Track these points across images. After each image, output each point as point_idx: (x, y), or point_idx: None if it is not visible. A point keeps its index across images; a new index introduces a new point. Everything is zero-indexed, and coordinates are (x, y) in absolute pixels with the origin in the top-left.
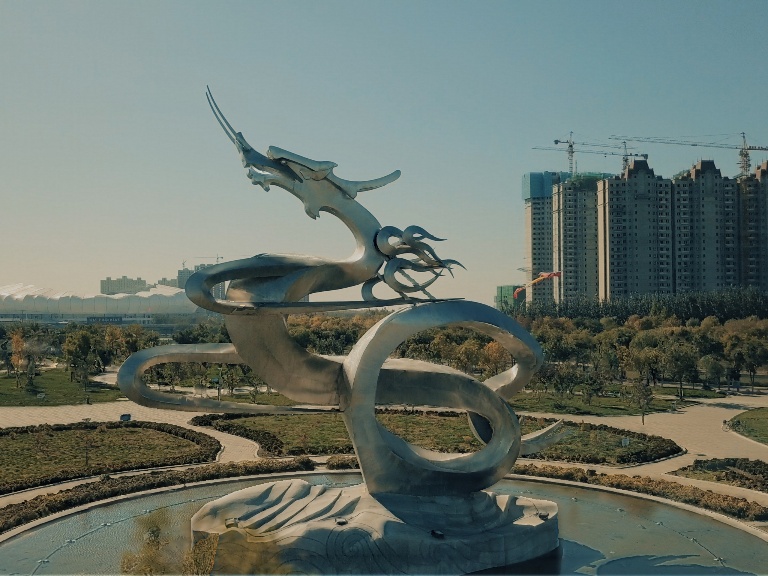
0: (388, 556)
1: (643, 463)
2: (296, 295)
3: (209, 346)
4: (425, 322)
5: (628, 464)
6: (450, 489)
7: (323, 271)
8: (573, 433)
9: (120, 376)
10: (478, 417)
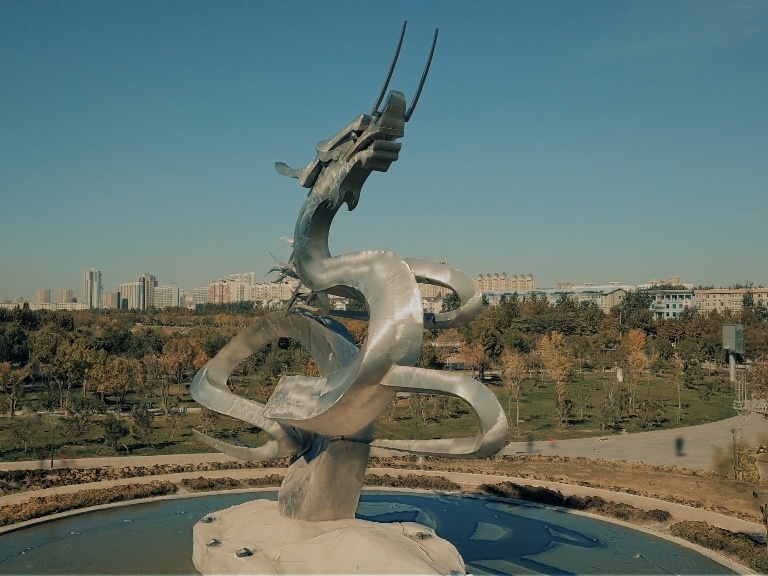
0: None
1: None
2: None
3: None
4: None
5: None
6: None
7: None
8: None
9: None
10: None
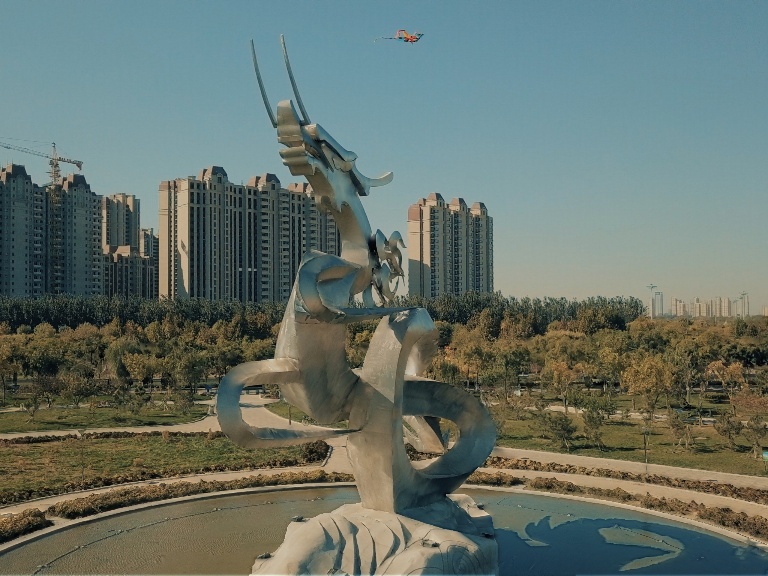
0: (483, 566)
1: (326, 459)
2: None
3: (273, 363)
4: (420, 330)
5: (317, 462)
6: (439, 495)
7: (357, 274)
8: (212, 442)
9: (220, 409)
10: (436, 422)
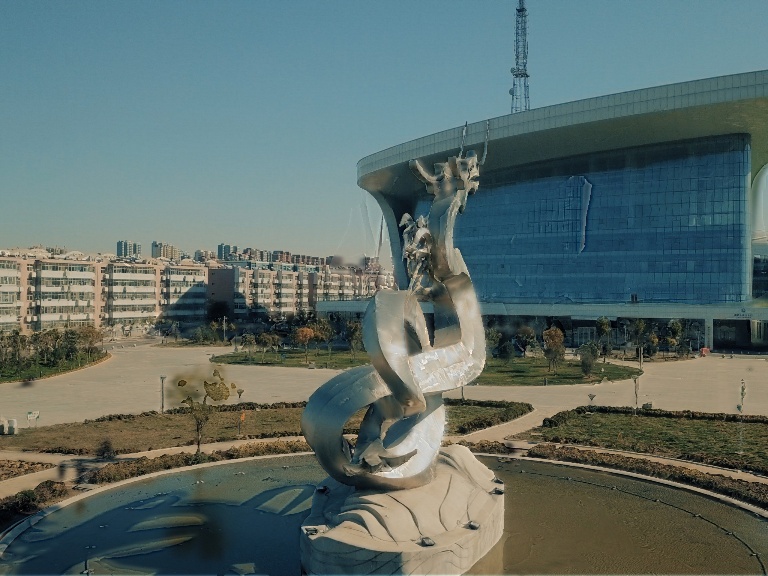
0: None
1: None
2: (442, 286)
3: None
4: None
5: None
6: None
7: None
8: None
9: None
10: None
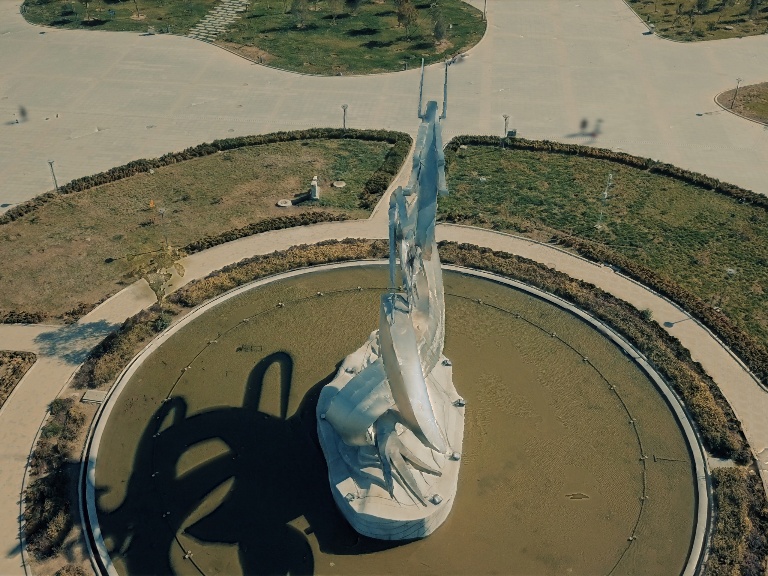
0: None
1: None
2: None
3: None
4: None
5: None
6: None
7: None
8: None
9: None
10: None
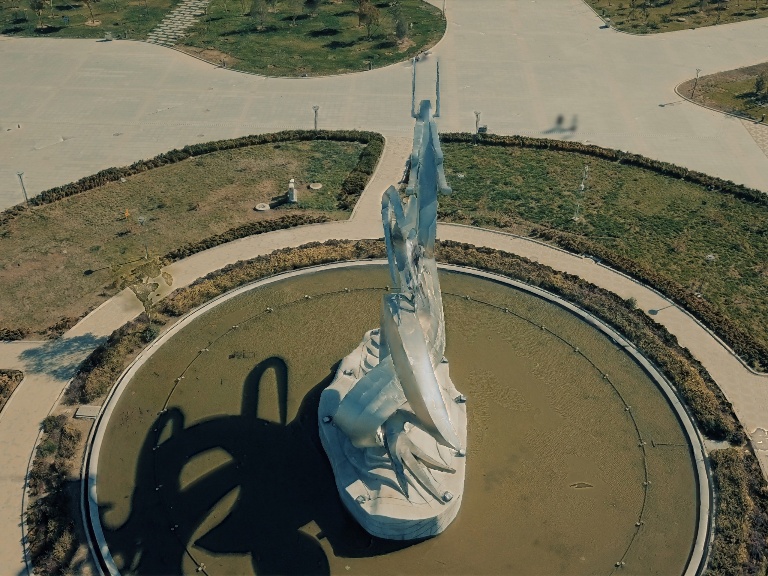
0: None
1: None
2: None
3: None
4: None
5: None
6: None
7: None
8: None
9: None
10: None
